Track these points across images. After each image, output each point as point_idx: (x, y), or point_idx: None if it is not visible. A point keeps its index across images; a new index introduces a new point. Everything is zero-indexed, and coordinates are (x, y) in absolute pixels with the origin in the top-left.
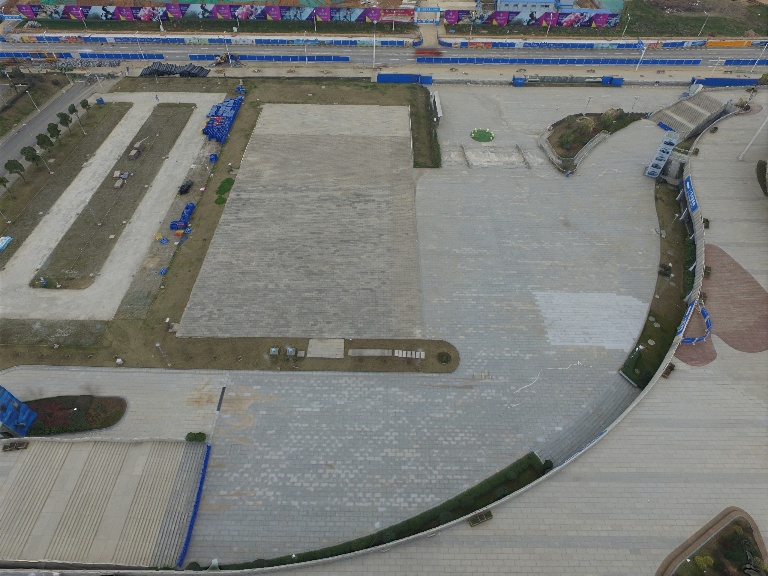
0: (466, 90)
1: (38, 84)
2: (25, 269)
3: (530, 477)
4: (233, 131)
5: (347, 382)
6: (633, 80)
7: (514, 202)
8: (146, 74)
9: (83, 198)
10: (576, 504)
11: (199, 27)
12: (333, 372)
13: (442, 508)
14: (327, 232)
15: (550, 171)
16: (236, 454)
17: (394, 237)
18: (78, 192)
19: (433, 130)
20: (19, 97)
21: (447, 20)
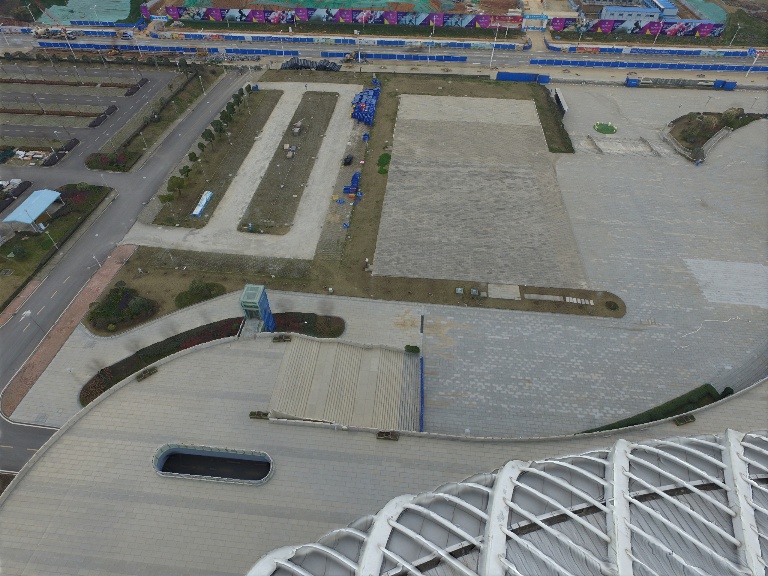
0: (582, 89)
1: (200, 72)
2: (230, 217)
3: (708, 403)
4: (378, 116)
5: (528, 319)
6: (746, 84)
7: (650, 184)
8: (286, 67)
9: (262, 165)
10: (767, 417)
11: (323, 29)
12: (514, 310)
13: (635, 419)
14: (483, 201)
15: (679, 160)
16: (445, 366)
17: (545, 208)
18: (257, 160)
19: (562, 121)
20: (188, 82)
21: (553, 27)
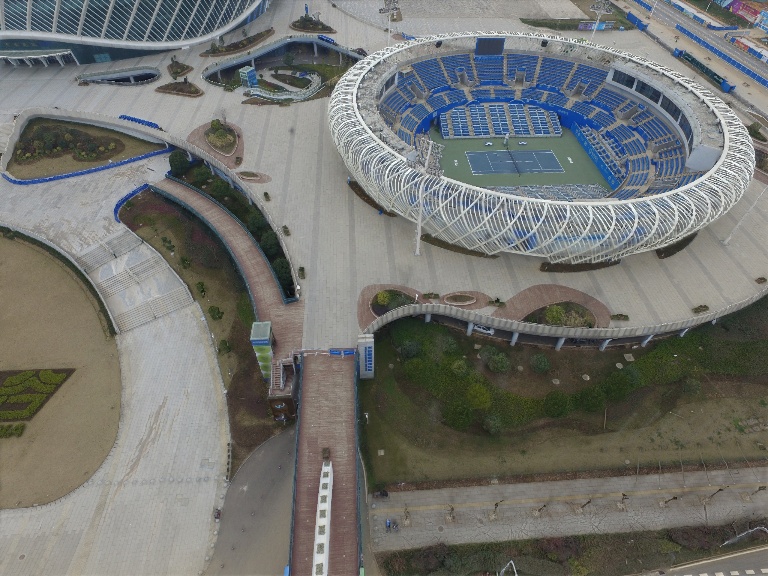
0: (644, 40)
1: None
2: None
3: None
4: None
5: None
6: None
7: None
8: None
9: None
10: None
11: None
12: None
13: None
14: (456, 4)
15: None
16: None
17: None
18: None
19: None
20: None
21: None
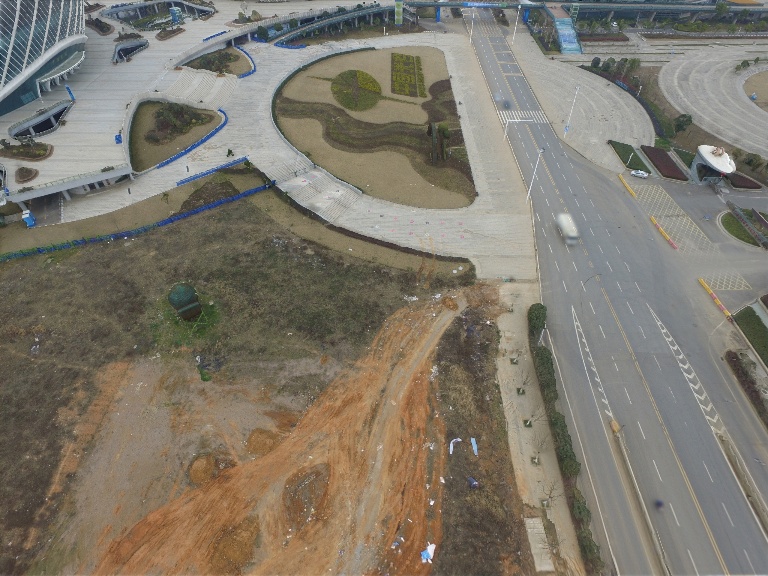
0: None
1: None
2: None
3: None
4: None
5: None
6: None
7: None
8: None
9: None
10: None
11: None
12: None
13: None
14: None
15: None
16: None
17: None
18: None
19: None
20: None
21: None
